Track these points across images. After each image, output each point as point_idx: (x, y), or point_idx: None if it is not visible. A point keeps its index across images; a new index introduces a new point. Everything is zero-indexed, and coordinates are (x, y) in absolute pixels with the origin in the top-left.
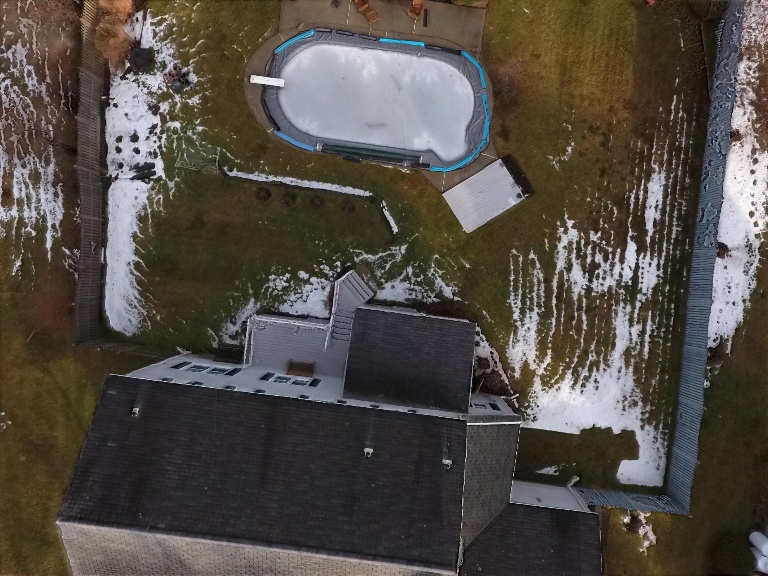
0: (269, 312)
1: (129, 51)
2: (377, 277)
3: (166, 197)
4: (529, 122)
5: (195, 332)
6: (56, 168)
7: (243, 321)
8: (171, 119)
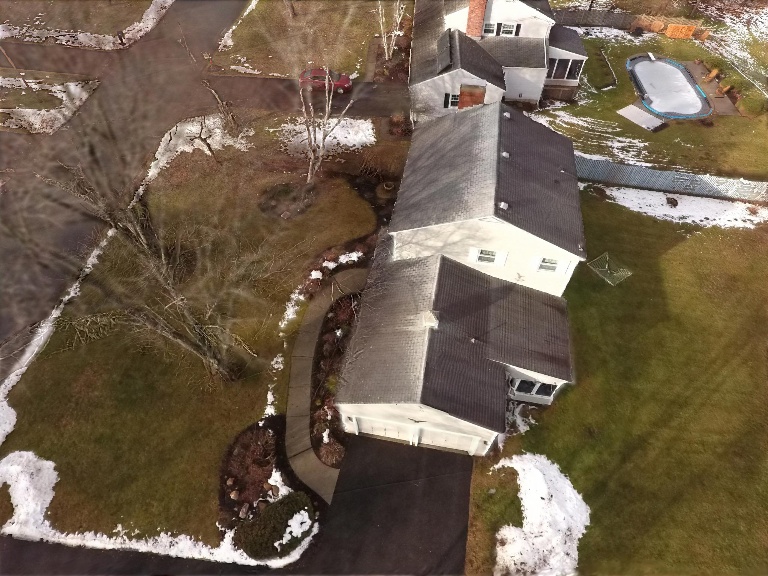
0: None
1: None
2: None
3: None
4: (693, 131)
5: None
6: None
7: None
8: None
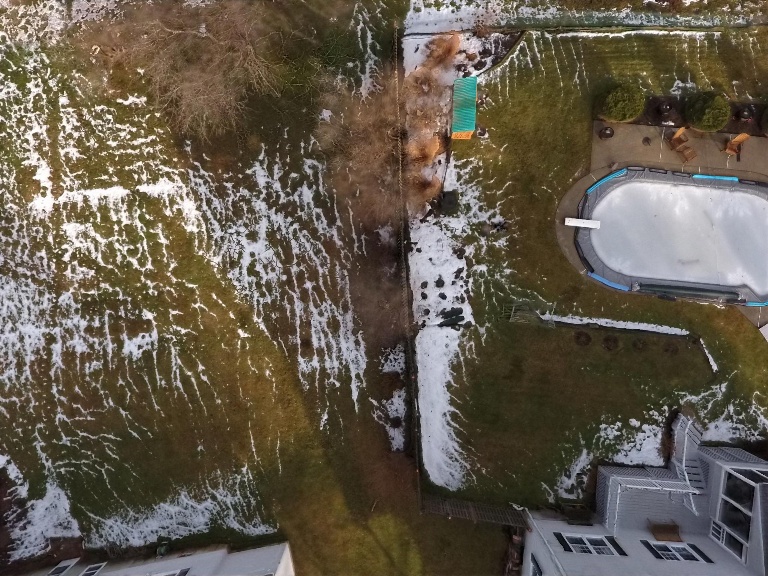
0: (603, 463)
1: (438, 197)
2: (701, 418)
3: (478, 344)
4: None
5: (528, 487)
6: (355, 315)
7: (577, 473)
8: (477, 262)
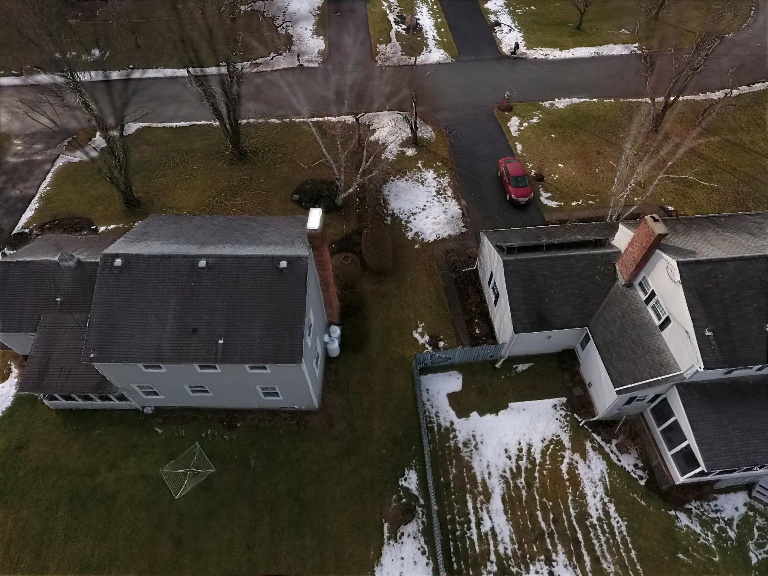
0: None
1: None
2: (759, 516)
3: None
4: None
5: None
6: None
7: None
8: None
